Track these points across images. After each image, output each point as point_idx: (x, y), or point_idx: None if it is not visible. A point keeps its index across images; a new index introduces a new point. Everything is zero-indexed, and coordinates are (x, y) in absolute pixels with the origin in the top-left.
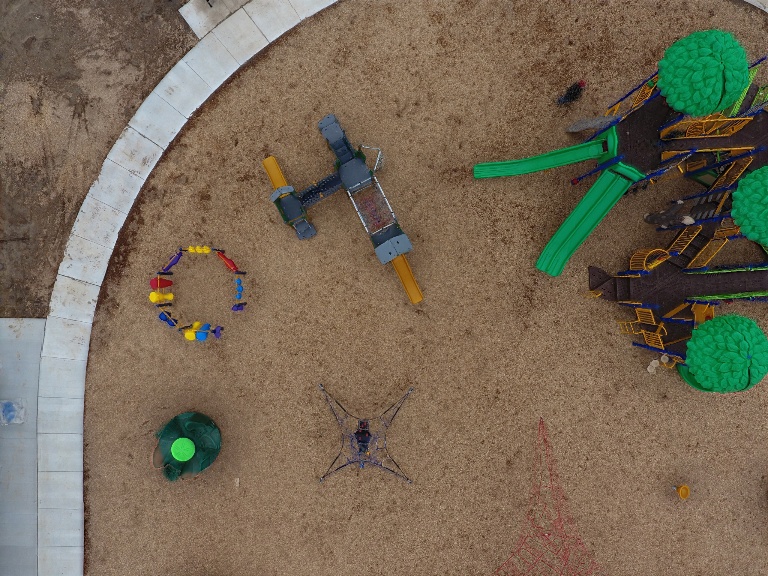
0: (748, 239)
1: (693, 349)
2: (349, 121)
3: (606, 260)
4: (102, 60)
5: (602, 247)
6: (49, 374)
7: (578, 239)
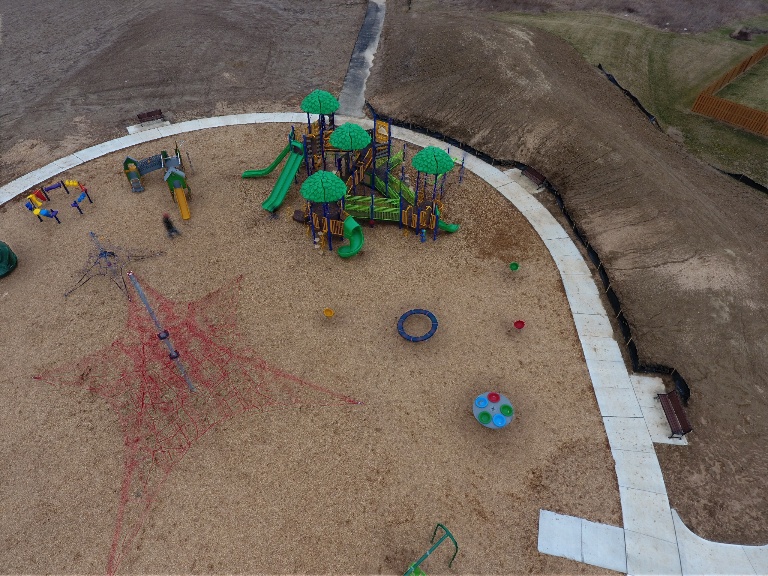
0: (334, 146)
1: (302, 184)
2: (187, 159)
3: None
4: (78, 137)
5: None
6: None
7: None
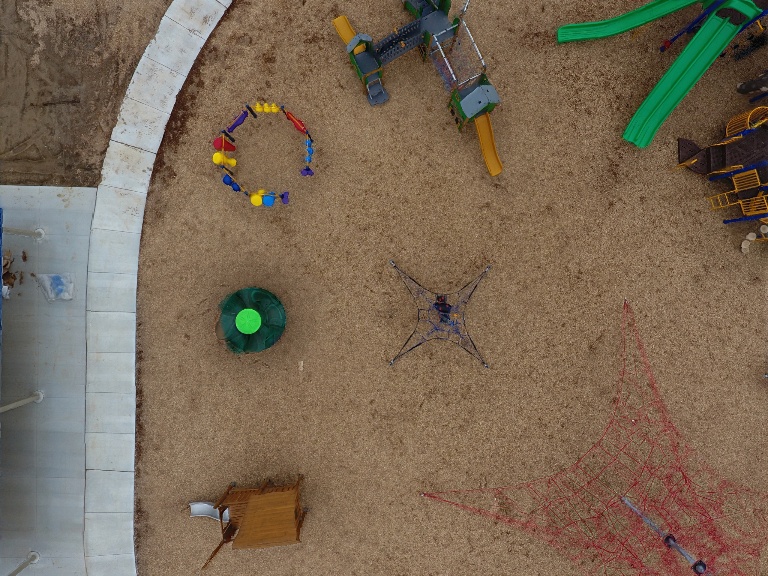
0: None
1: None
2: None
3: (696, 133)
4: None
5: (691, 119)
6: (100, 247)
7: (672, 103)
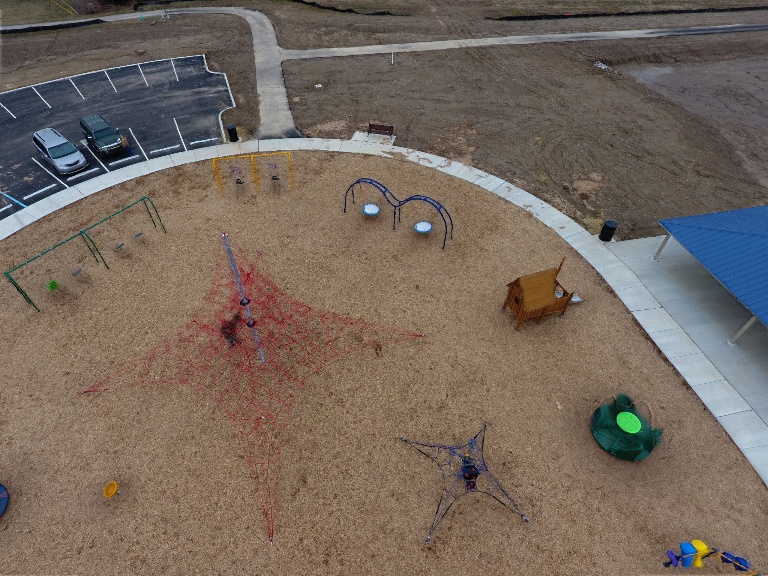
0: None
1: None
2: None
3: None
4: None
5: None
6: None
7: None
